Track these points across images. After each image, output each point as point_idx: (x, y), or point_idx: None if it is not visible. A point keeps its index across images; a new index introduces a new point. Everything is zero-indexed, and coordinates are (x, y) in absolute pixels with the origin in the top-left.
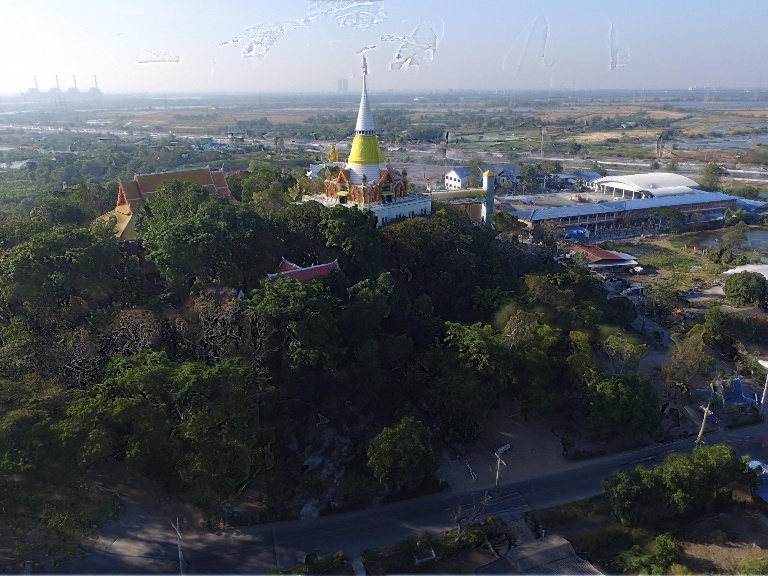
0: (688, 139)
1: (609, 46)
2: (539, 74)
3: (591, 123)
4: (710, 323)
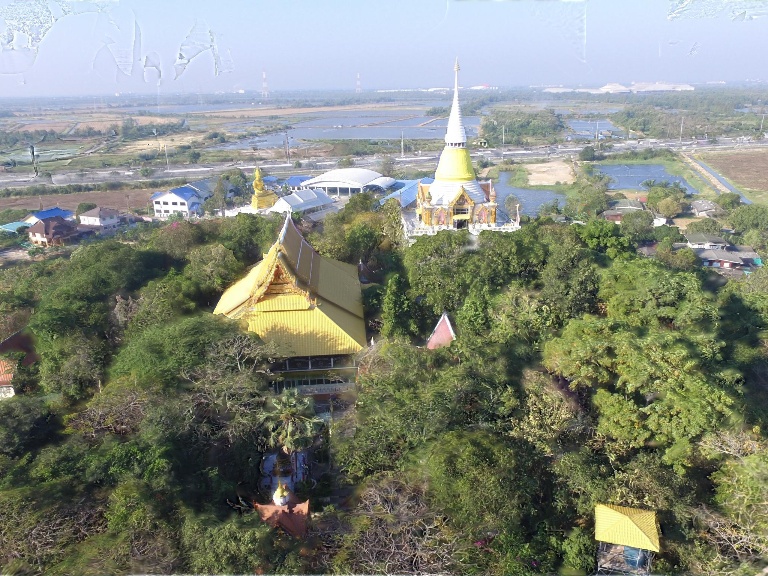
0: (239, 140)
1: (210, 51)
2: (142, 79)
3: (121, 132)
4: (691, 260)
